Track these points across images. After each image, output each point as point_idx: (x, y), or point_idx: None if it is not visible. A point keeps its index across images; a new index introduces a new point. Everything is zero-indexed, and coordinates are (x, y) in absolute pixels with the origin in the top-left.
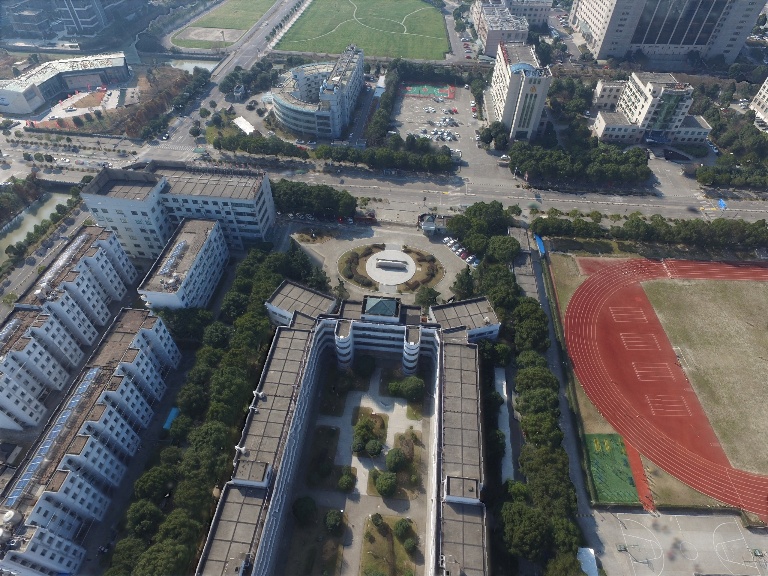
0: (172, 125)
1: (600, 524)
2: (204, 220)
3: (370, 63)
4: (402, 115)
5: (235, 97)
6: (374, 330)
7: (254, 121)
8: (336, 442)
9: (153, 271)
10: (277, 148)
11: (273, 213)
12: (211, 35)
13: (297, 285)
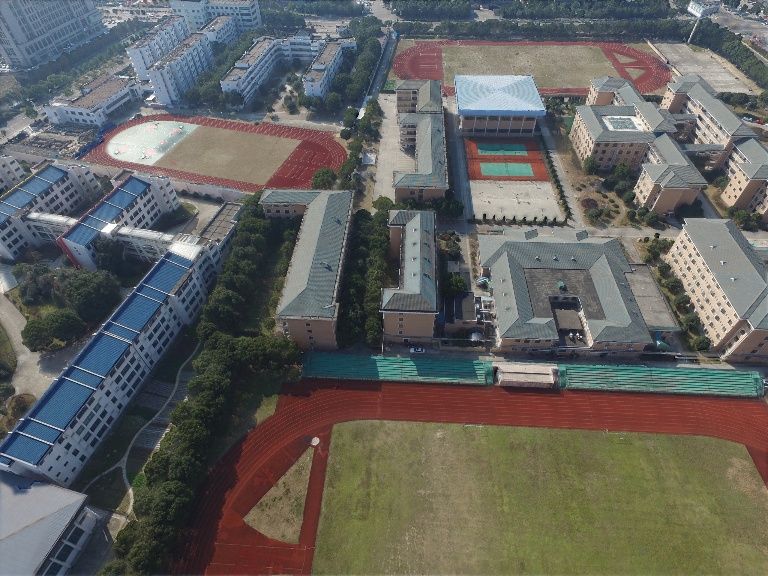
0: None
1: (380, 95)
2: (226, 16)
3: None
4: None
5: None
6: (299, 45)
7: None
8: (280, 82)
9: (203, 28)
10: (266, 4)
11: (261, 23)
12: None
13: (268, 35)
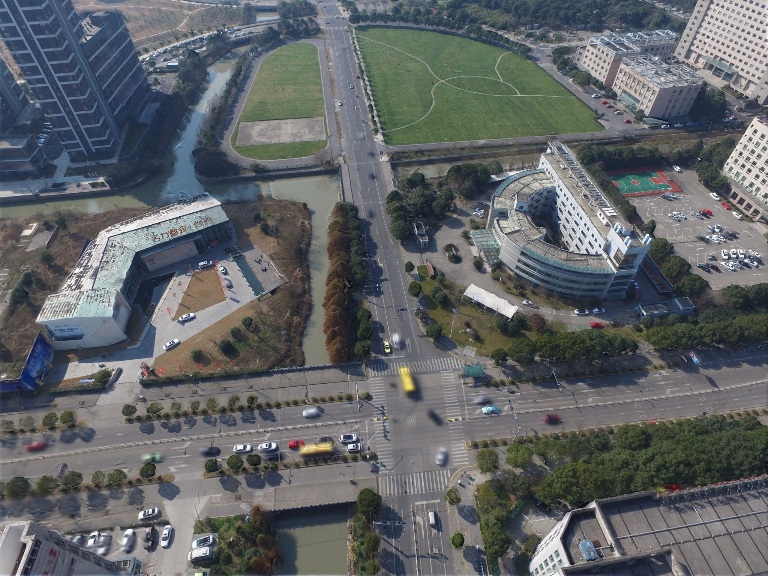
0: (374, 318)
1: None
2: None
3: (526, 148)
4: (655, 232)
5: (422, 244)
6: None
7: (482, 284)
8: None
9: None
10: None
11: None
12: (283, 133)
13: None
